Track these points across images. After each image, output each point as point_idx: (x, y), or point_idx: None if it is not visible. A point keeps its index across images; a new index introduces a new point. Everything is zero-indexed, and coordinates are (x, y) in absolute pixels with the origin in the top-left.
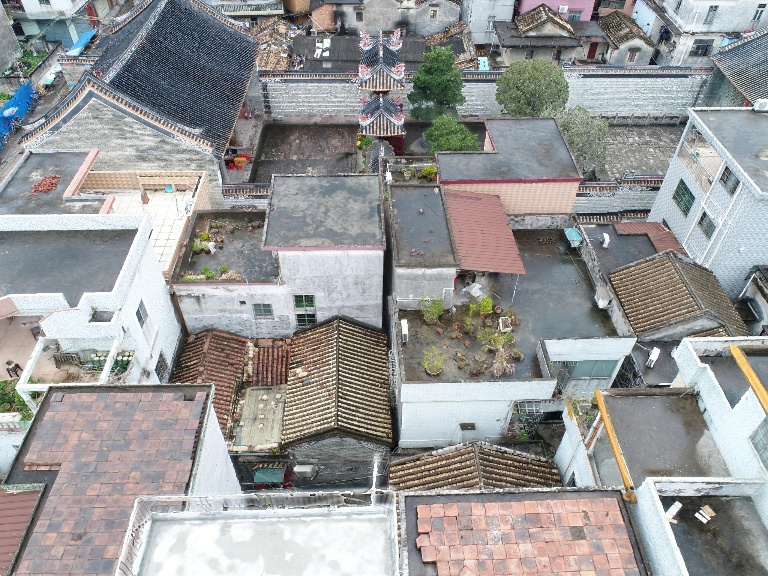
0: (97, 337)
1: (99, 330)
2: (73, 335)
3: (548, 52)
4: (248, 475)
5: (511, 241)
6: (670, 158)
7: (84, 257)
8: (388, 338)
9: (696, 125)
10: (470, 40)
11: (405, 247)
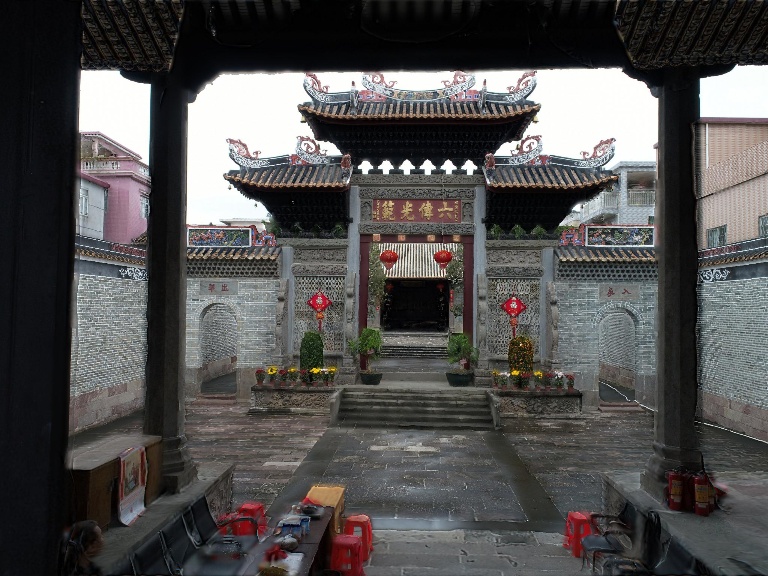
0: None
1: None
2: None
3: None
4: None
5: None
6: None
7: None
8: None
9: (640, 167)
10: None
11: None
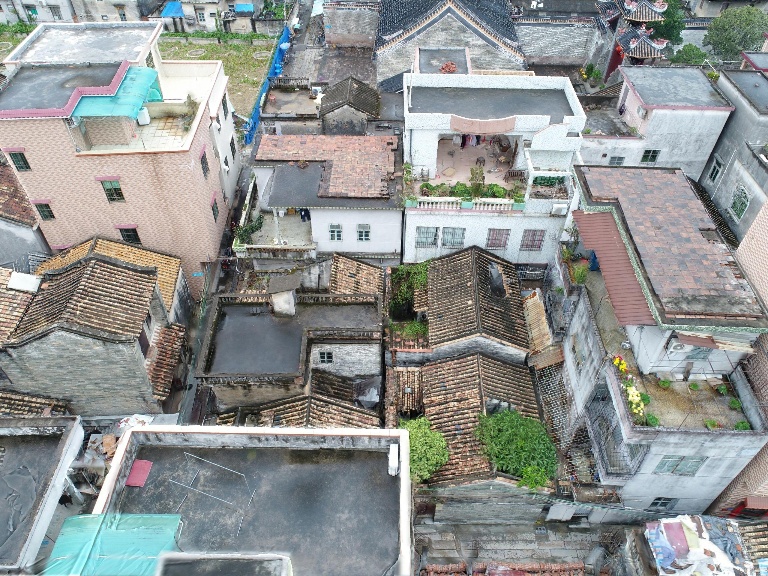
0: (564, 150)
1: (570, 143)
2: (549, 147)
3: (741, 6)
4: None
5: None
6: None
7: (532, 103)
8: (705, 189)
9: None
10: None
11: (760, 104)
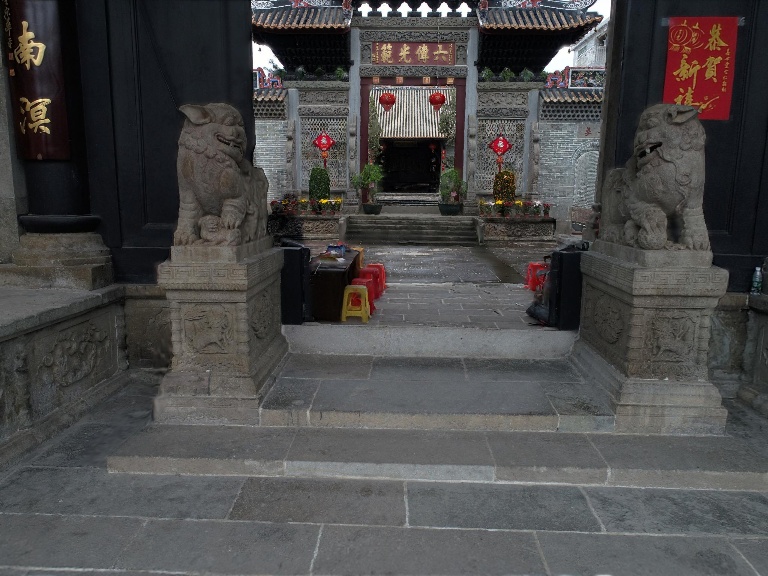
0: None
1: None
2: None
3: None
4: None
5: None
6: None
7: None
8: None
9: None
10: None
11: None
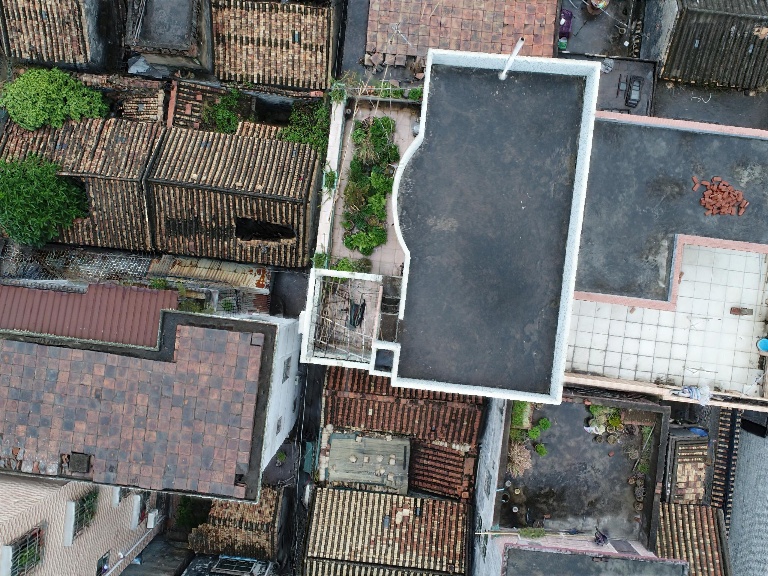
0: None
1: None
2: None
3: None
4: (311, 438)
5: None
6: None
7: (498, 316)
8: None
9: None
10: None
11: None
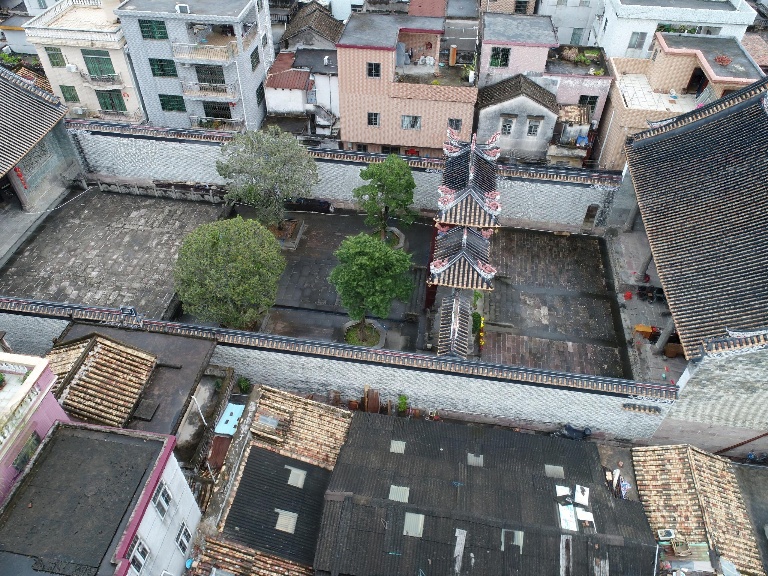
0: None
1: None
2: None
3: None
4: None
5: (412, 5)
6: (88, 257)
7: None
8: None
9: None
10: (228, 466)
11: None
